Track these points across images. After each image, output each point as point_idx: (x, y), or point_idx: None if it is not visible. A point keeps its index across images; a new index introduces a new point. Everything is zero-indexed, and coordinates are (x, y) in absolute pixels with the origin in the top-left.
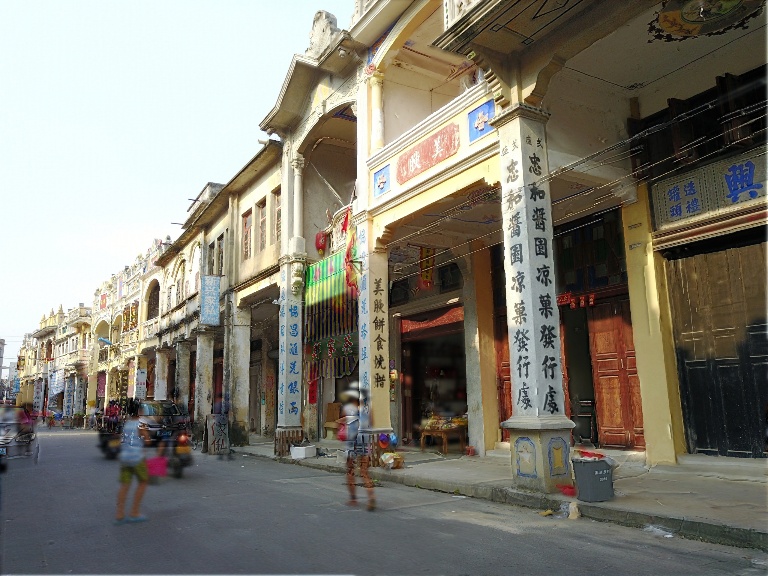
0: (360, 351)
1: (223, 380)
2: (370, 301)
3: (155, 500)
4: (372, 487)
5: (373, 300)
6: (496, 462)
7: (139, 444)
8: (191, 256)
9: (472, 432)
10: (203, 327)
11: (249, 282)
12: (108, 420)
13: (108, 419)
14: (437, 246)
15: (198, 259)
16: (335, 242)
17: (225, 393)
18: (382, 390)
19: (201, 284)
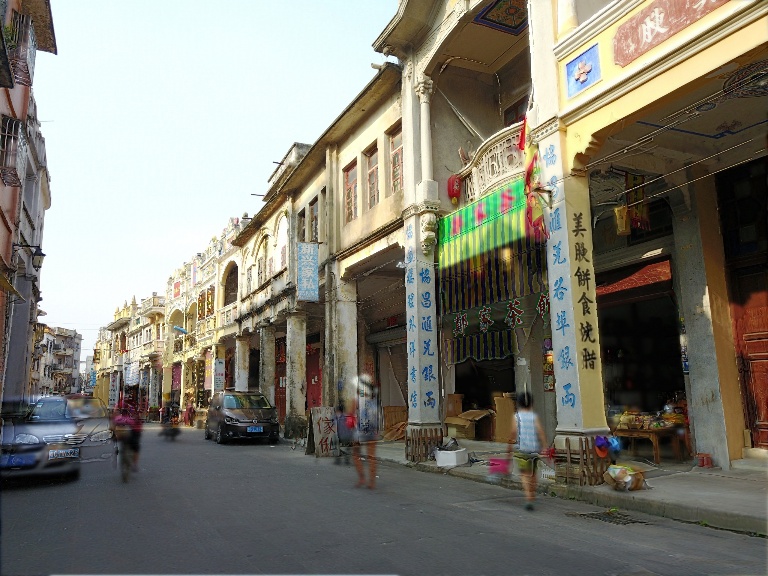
0: (553, 317)
1: (326, 366)
2: (569, 245)
3: (307, 548)
4: (624, 523)
5: (573, 243)
6: (766, 479)
7: (227, 442)
8: (275, 229)
9: (702, 433)
10: (294, 307)
11: (358, 246)
12: (185, 413)
13: (185, 412)
14: (646, 171)
15: (284, 231)
16: (477, 185)
17: (329, 382)
18: (593, 373)
19: (297, 252)
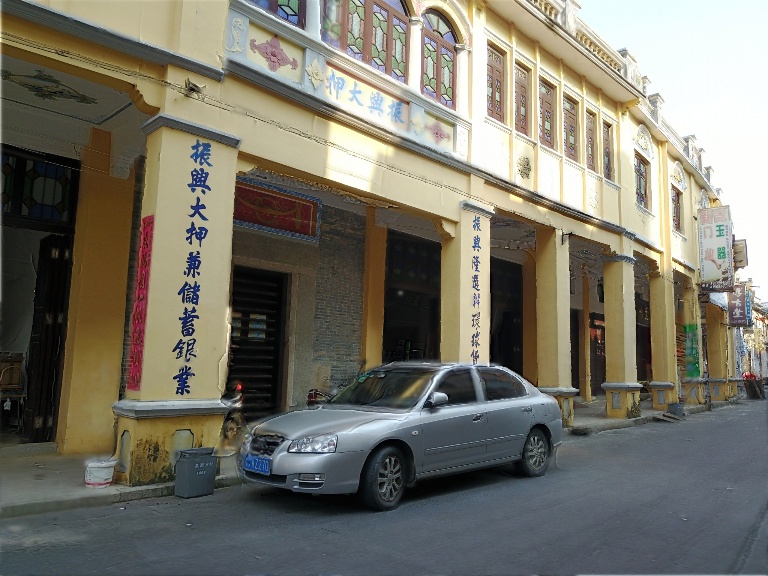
0: None
1: None
2: None
3: None
4: None
5: None
6: None
7: None
8: None
9: None
10: None
11: None
12: None
13: None
14: None
15: None
16: None
17: None
18: None
19: None
